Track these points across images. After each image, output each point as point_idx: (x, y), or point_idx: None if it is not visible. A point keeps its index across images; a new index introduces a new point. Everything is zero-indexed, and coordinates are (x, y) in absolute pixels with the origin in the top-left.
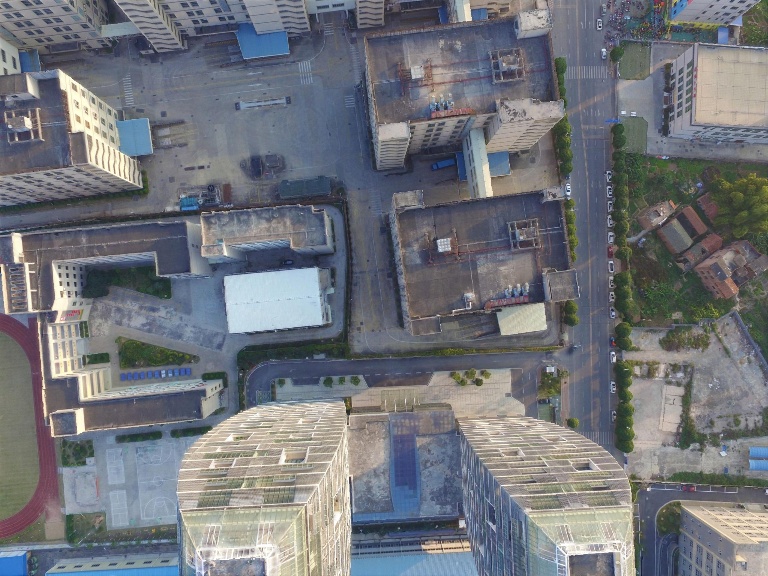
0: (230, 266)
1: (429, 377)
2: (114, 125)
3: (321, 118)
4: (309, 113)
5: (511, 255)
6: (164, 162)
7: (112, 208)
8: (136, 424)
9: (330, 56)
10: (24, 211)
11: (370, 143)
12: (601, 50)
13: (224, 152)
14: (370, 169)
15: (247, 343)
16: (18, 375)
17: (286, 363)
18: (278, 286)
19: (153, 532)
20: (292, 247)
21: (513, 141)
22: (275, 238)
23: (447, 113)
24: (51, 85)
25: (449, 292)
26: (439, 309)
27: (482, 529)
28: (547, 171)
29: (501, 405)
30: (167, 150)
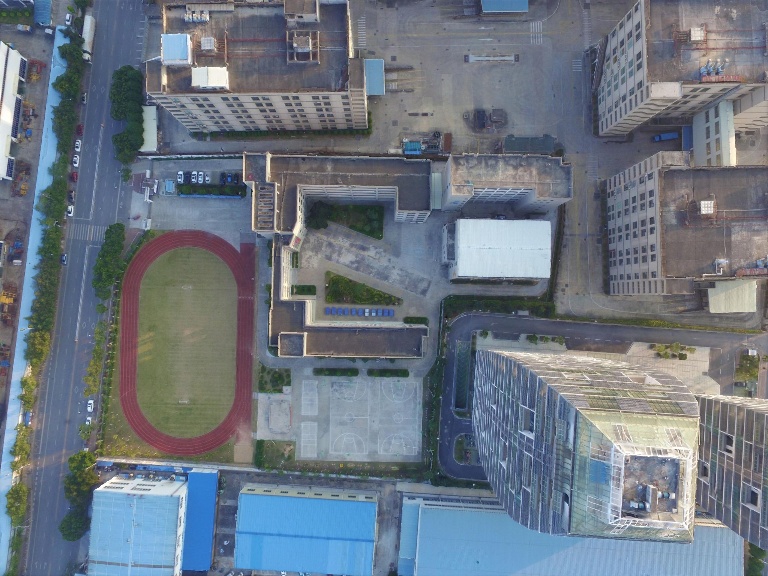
0: (443, 214)
1: (628, 346)
2: None
3: (547, 79)
4: (536, 73)
5: (766, 226)
6: (389, 105)
7: (334, 145)
8: (356, 354)
9: (562, 19)
10: (249, 138)
11: (593, 108)
12: None
13: (449, 102)
14: (590, 134)
15: (451, 292)
16: (225, 297)
17: (488, 316)
18: (511, 235)
19: (341, 467)
20: (537, 196)
21: (755, 118)
22: (521, 186)
23: (718, 78)
24: (331, 10)
25: (701, 256)
26: (689, 271)
27: (762, 485)
28: (766, 155)
29: (697, 383)
30: (393, 94)
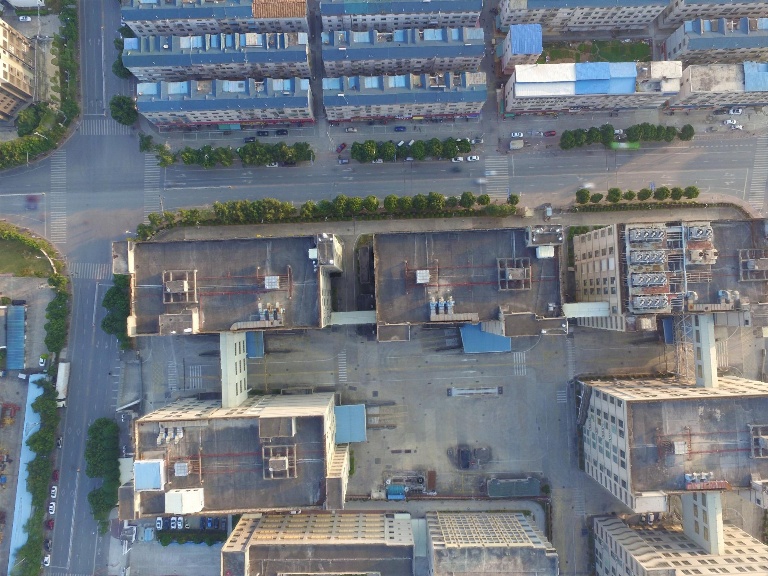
0: None
1: None
2: (333, 413)
3: (531, 411)
4: (520, 405)
5: None
6: (372, 442)
7: None
8: None
9: (546, 349)
10: None
11: (579, 442)
12: None
13: (432, 437)
14: (576, 468)
15: None
16: None
17: None
18: None
19: None
20: None
21: None
22: None
23: (703, 486)
24: (308, 420)
25: None
26: None
27: None
28: None
29: None
30: (376, 431)
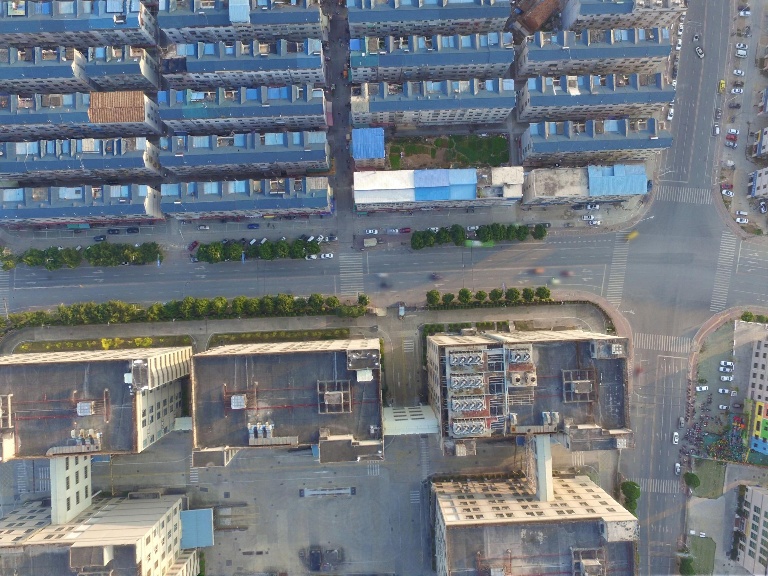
0: None
1: None
2: (178, 519)
3: (385, 512)
4: (373, 506)
5: None
6: (223, 544)
7: None
8: None
9: (399, 449)
10: None
11: (432, 542)
12: (675, 465)
13: (284, 539)
14: (429, 569)
15: None
16: None
17: None
18: None
19: None
20: None
21: None
22: None
23: None
24: (126, 545)
25: None
26: None
27: None
28: None
29: None
30: (227, 532)
